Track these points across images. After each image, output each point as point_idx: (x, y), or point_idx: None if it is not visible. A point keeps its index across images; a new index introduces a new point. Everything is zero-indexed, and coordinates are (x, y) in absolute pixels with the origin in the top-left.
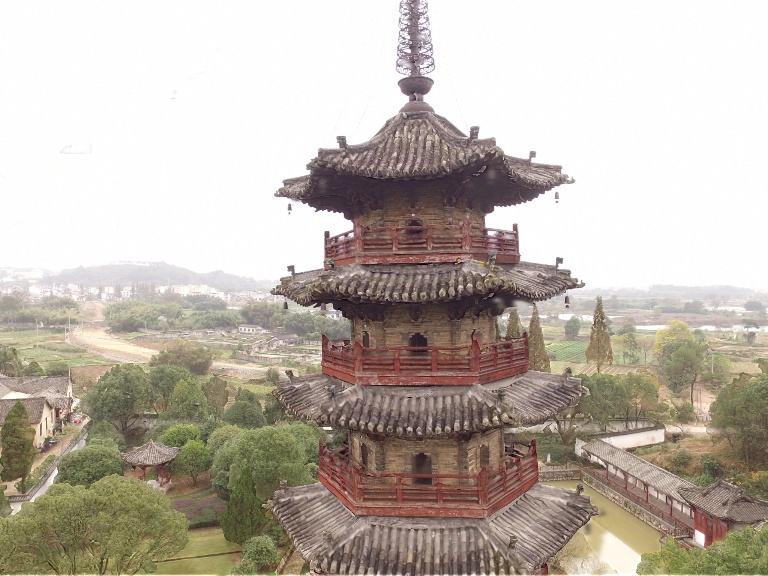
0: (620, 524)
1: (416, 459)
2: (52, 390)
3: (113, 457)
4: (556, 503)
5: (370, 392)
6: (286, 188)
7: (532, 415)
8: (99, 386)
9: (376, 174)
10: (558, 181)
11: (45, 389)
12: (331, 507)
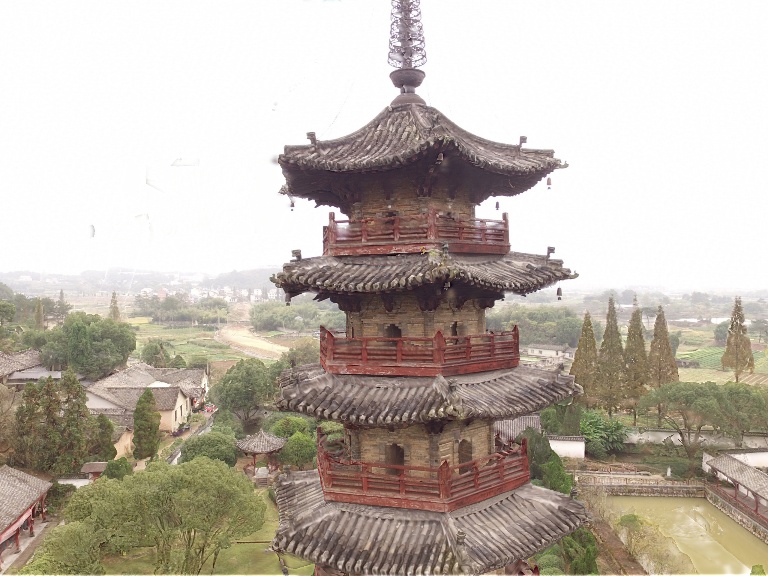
0: (748, 550)
1: (391, 450)
2: (189, 381)
3: (227, 443)
4: (546, 506)
5: (342, 381)
6: (286, 186)
7: (494, 409)
8: (224, 378)
9: (335, 167)
10: (547, 166)
11: (183, 380)
12: (321, 493)
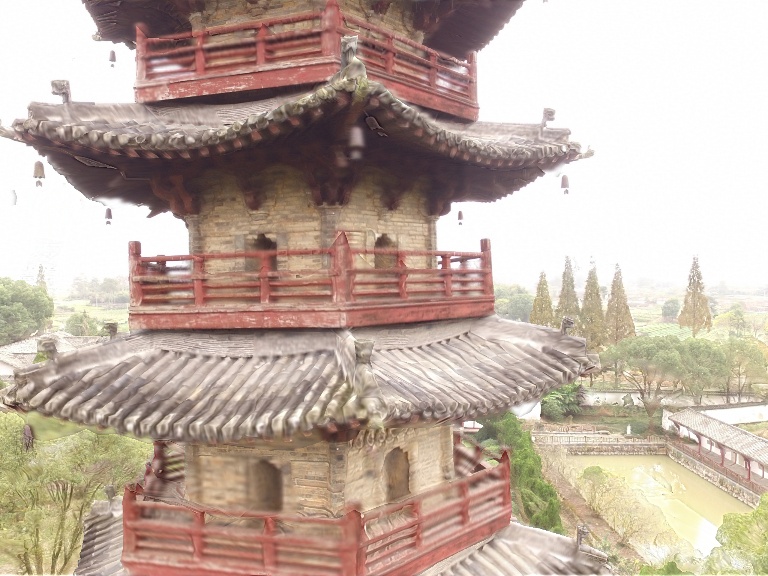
0: (714, 506)
1: (255, 248)
2: None
3: None
4: (522, 348)
5: (163, 120)
6: None
7: None
8: None
9: None
10: None
11: None
12: None
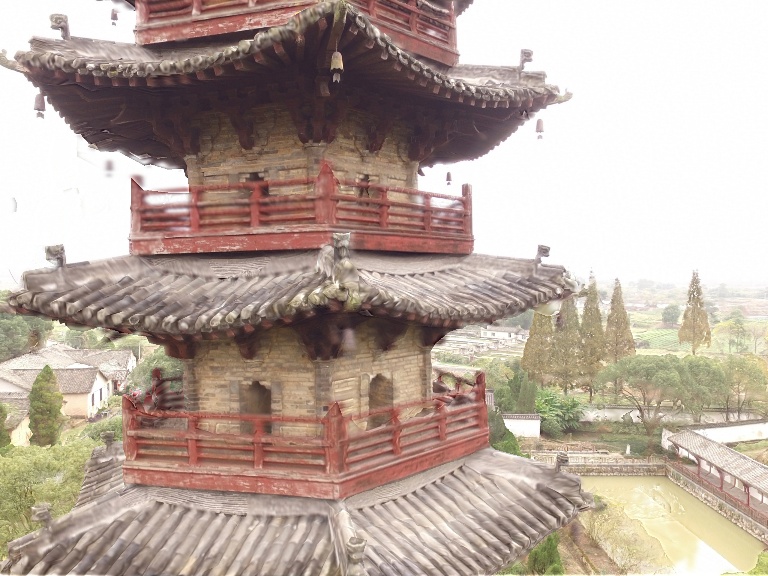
0: (713, 530)
1: (250, 393)
2: (113, 363)
3: None
4: (516, 484)
5: (158, 270)
6: None
7: (425, 303)
8: (149, 358)
9: None
10: None
11: (106, 361)
12: None
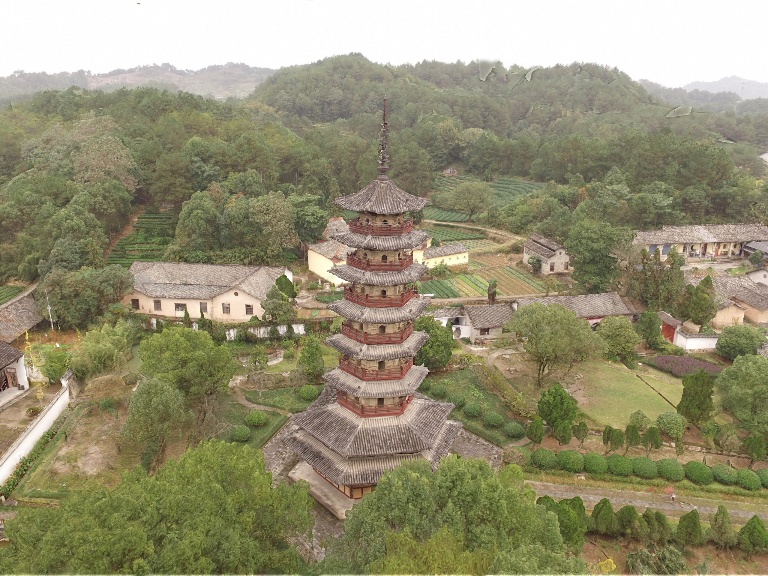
0: None
1: None
2: None
3: (753, 341)
4: None
5: None
6: None
7: None
8: None
9: None
10: None
11: None
12: None
